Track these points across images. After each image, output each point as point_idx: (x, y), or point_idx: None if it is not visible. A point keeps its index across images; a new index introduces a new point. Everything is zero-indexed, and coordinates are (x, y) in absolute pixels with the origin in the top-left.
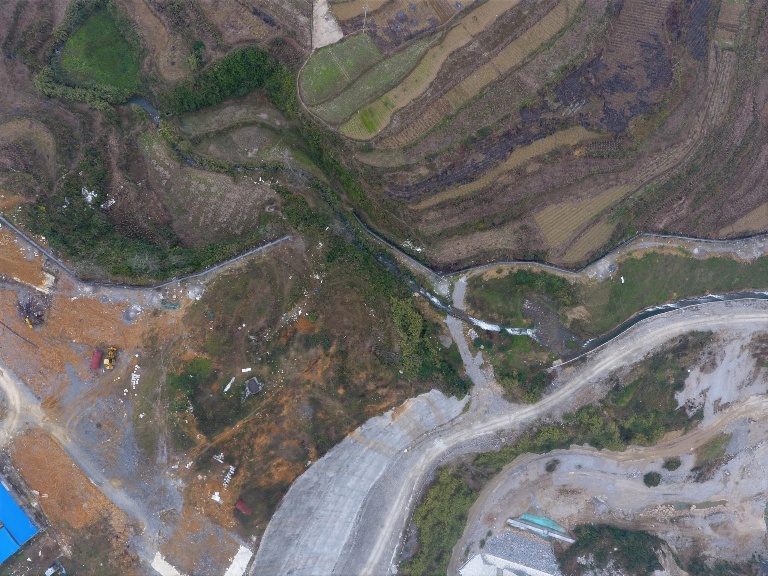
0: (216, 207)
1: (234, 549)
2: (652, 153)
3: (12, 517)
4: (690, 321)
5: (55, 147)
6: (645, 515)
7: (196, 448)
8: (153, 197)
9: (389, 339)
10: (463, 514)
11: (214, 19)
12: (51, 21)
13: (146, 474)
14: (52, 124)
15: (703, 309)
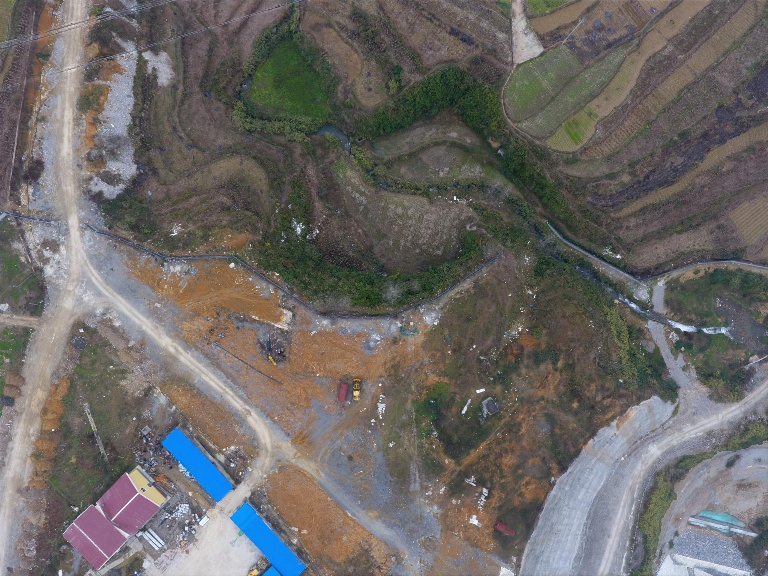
0: (415, 229)
1: (496, 571)
2: None
3: (280, 556)
4: None
5: (268, 182)
6: None
7: (446, 473)
8: (353, 224)
9: (607, 349)
10: (662, 517)
11: (412, 42)
12: (239, 56)
13: (401, 503)
14: (261, 159)
15: None
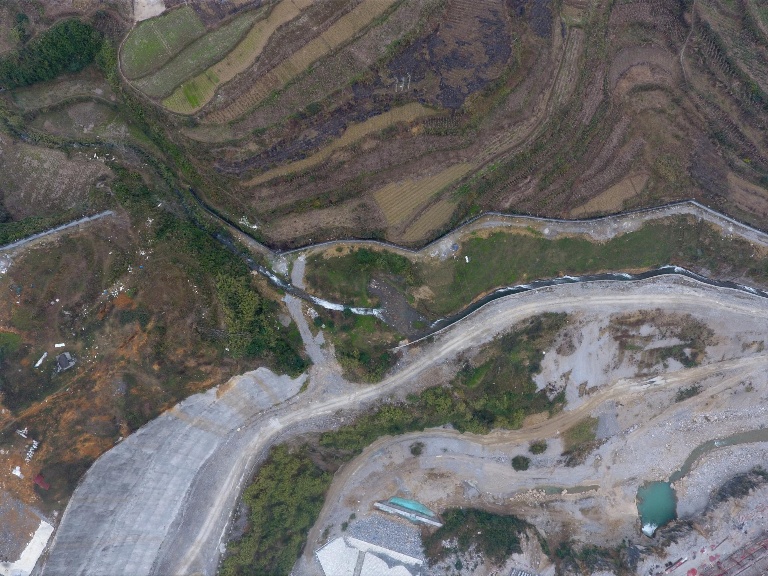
0: (49, 183)
1: (35, 524)
2: (494, 131)
3: None
4: (543, 302)
5: None
6: (515, 499)
7: (0, 423)
8: None
9: (215, 316)
10: (315, 495)
11: None
12: None
13: None
14: None
15: (557, 290)
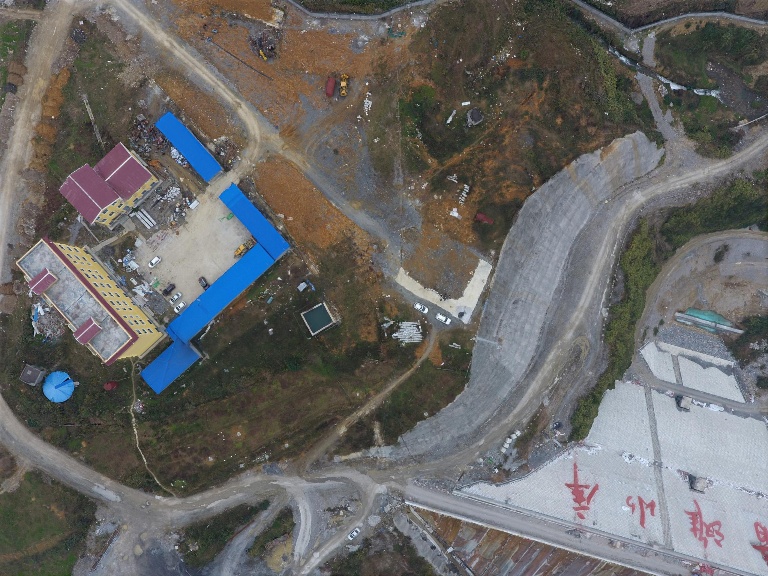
0: None
1: (474, 263)
2: None
3: (265, 233)
4: None
5: None
6: None
7: (429, 171)
8: None
9: (594, 81)
10: (646, 288)
11: None
12: None
13: (384, 195)
14: None
15: None
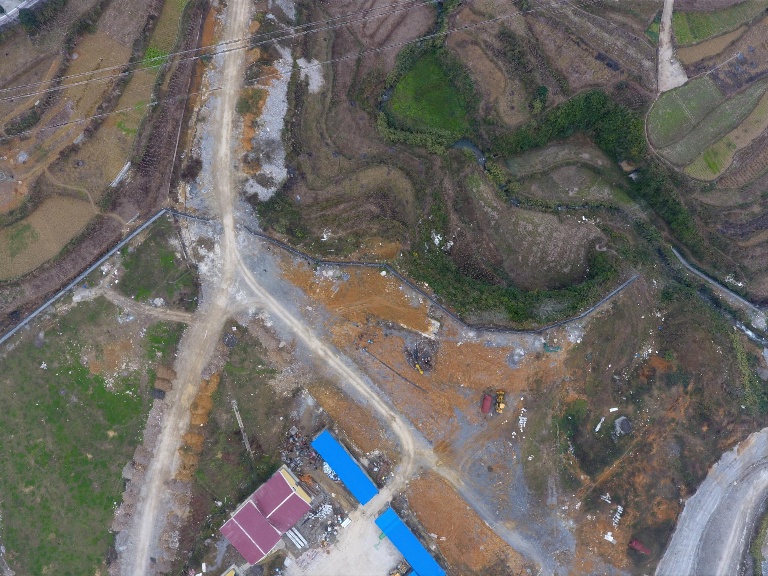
0: (544, 246)
1: None
2: None
3: (422, 561)
4: None
5: (413, 193)
6: None
7: (582, 489)
8: (485, 238)
9: None
10: None
11: (559, 65)
12: None
13: (538, 515)
14: (407, 170)
15: None
